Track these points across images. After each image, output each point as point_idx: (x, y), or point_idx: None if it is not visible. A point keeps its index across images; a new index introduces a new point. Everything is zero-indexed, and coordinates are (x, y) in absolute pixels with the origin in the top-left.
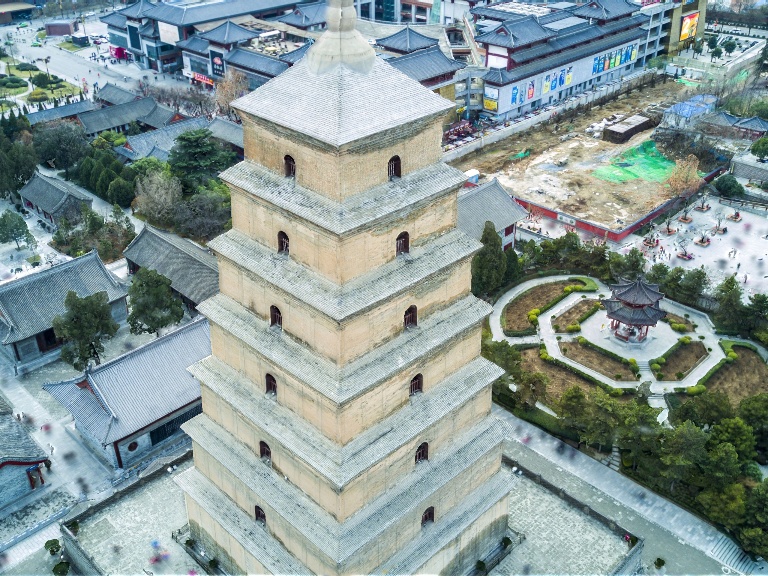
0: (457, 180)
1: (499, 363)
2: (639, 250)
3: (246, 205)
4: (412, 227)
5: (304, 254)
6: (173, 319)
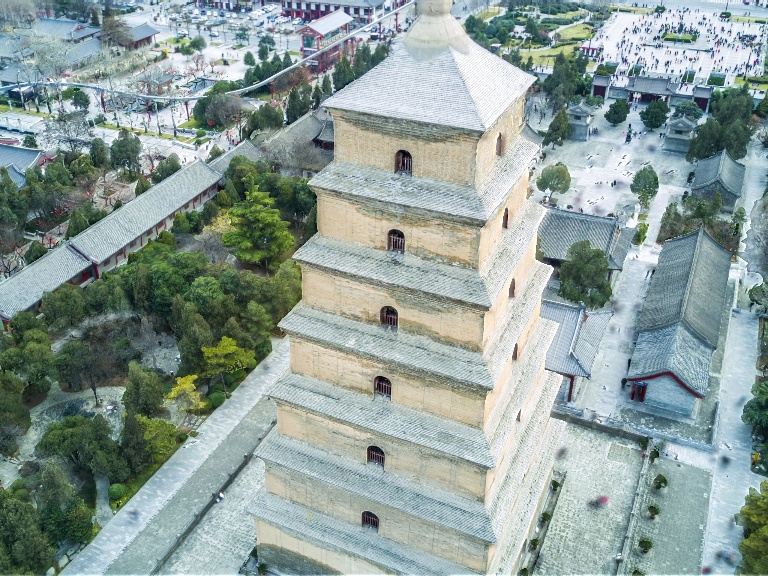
0: (467, 213)
1: (755, 571)
2: None
3: None
4: (410, 232)
5: None
6: (582, 299)
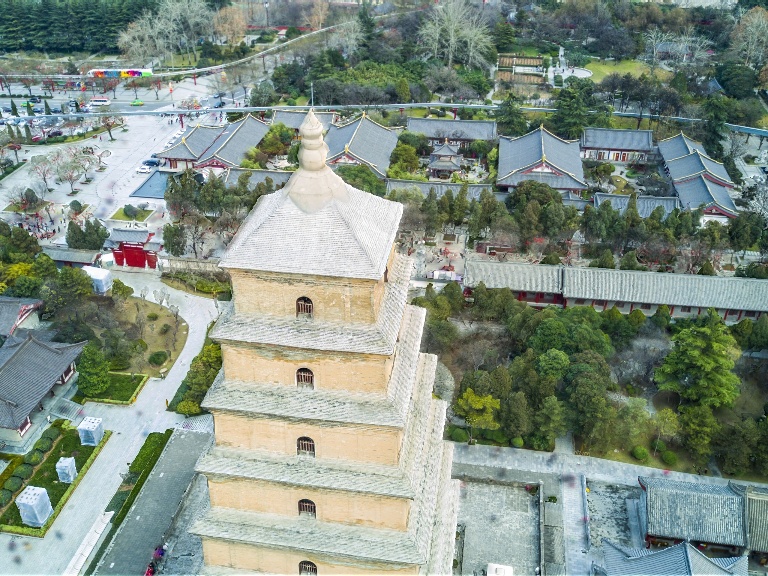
0: None
1: None
2: None
3: None
4: None
5: None
6: None
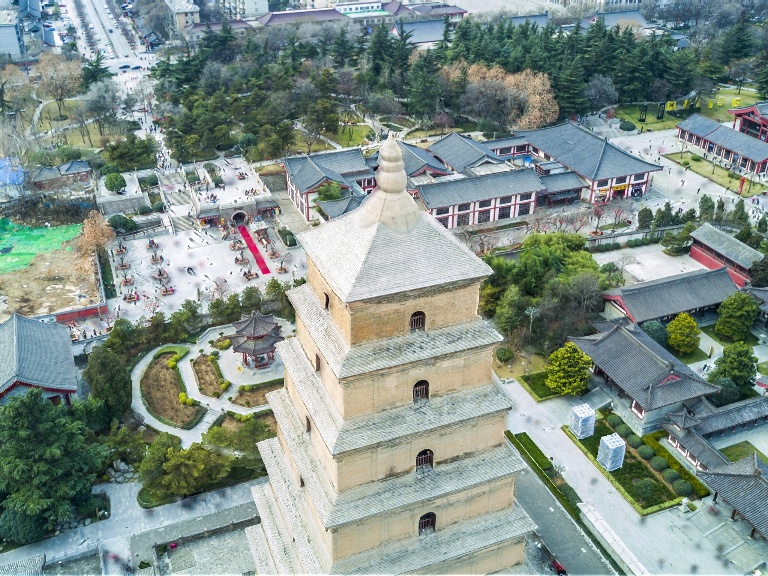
0: None
1: None
2: (190, 300)
3: (369, 386)
4: None
5: (450, 384)
6: None
